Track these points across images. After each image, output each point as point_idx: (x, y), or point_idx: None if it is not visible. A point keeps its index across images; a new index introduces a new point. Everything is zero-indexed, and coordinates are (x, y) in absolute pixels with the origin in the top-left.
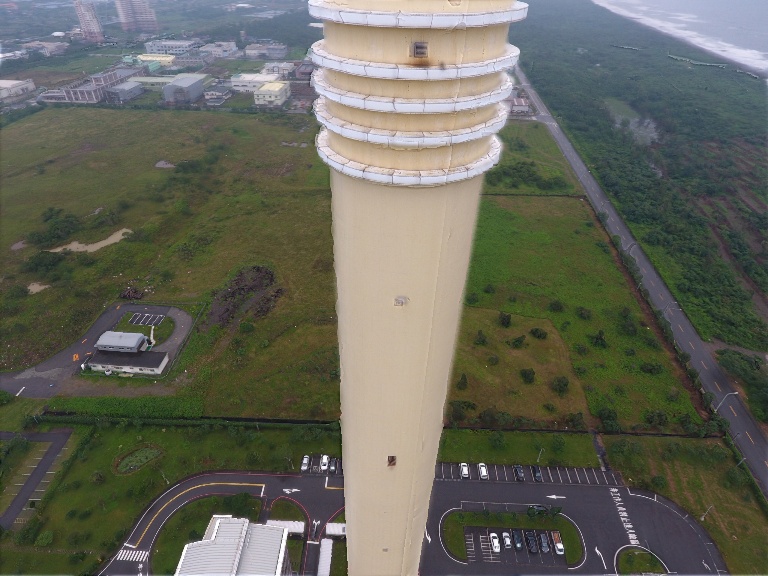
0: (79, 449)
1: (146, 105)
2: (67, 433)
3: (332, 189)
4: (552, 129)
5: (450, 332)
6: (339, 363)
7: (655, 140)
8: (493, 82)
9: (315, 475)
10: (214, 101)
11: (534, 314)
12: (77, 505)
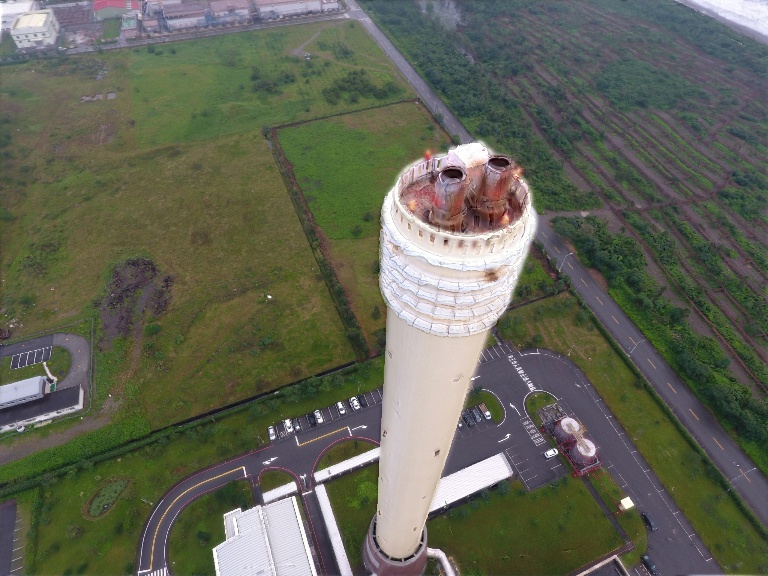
0: (36, 515)
1: None
2: (11, 506)
3: (397, 324)
4: (367, 26)
5: None
6: (262, 333)
7: (459, 23)
8: None
9: (285, 439)
10: None
11: None
12: (68, 564)
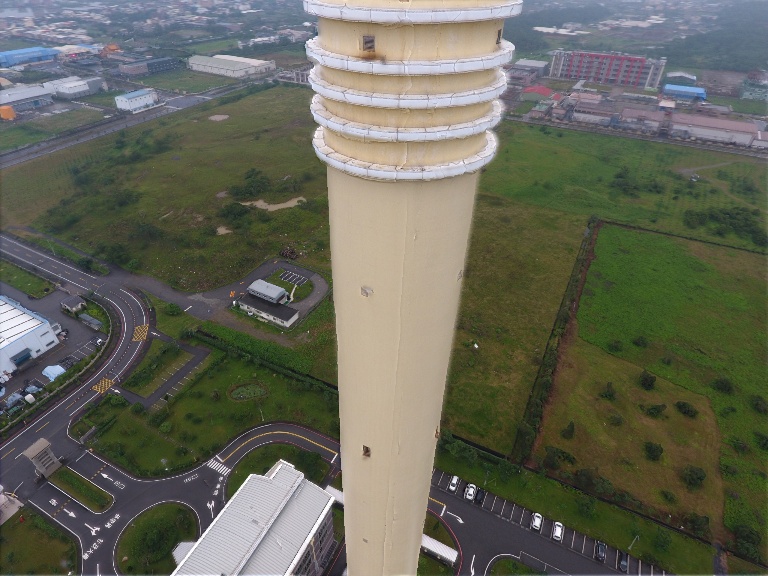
0: (210, 367)
1: None
2: (207, 352)
3: None
4: None
5: (432, 341)
6: None
7: None
8: (452, 84)
9: None
10: None
11: (689, 385)
12: (195, 411)
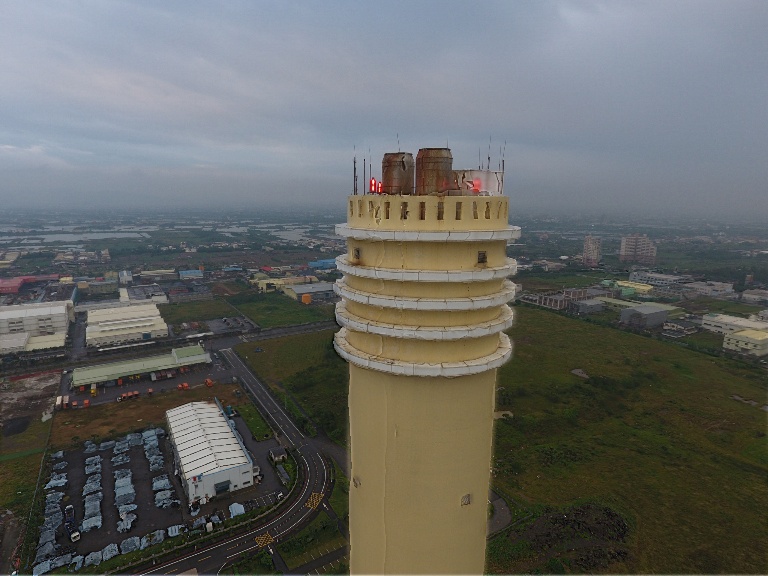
0: None
1: (598, 321)
2: None
3: None
4: None
5: (428, 575)
6: None
7: None
8: (416, 289)
9: None
10: (671, 333)
11: None
12: None
